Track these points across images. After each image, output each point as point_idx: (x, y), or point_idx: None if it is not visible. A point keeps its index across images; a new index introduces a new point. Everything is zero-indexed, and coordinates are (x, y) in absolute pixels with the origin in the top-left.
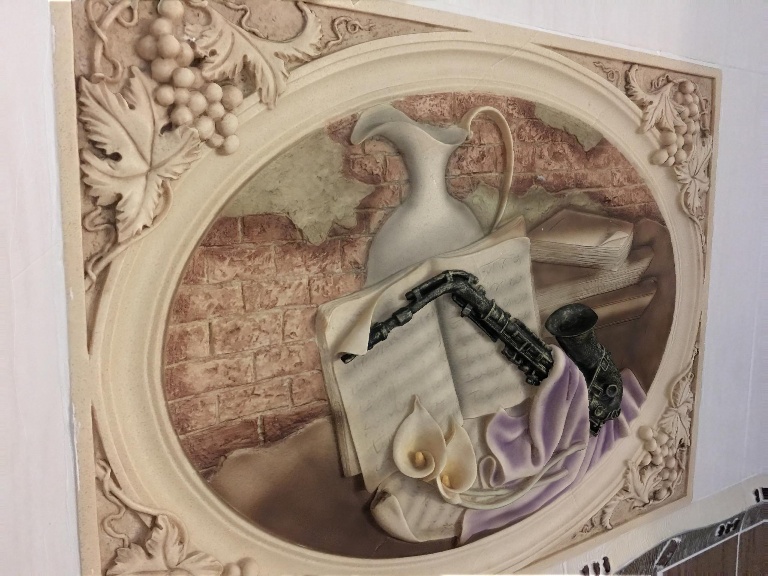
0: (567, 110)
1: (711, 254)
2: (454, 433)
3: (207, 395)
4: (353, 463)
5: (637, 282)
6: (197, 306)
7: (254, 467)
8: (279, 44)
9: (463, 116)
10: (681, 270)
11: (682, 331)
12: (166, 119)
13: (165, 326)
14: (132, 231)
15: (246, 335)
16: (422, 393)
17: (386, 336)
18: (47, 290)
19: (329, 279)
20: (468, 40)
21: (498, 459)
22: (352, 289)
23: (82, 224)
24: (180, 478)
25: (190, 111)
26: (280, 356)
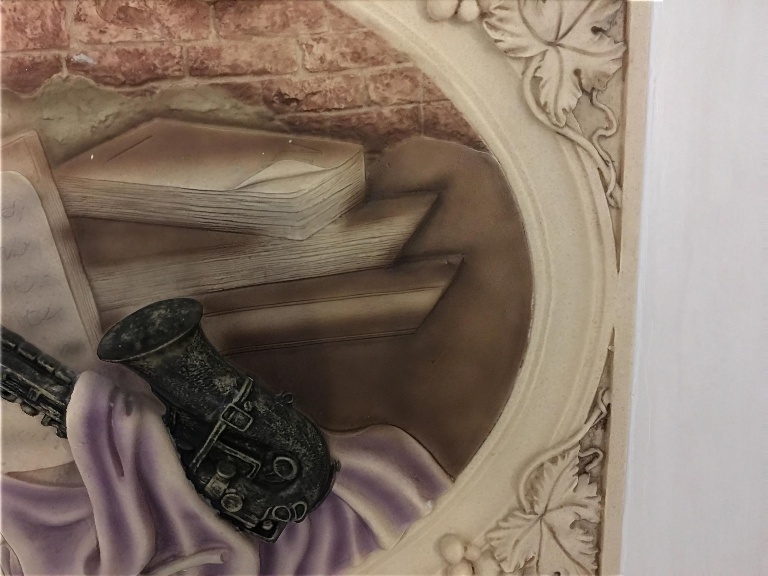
0: None
1: (643, 211)
2: None
3: None
4: None
5: (385, 263)
6: None
7: None
8: None
9: None
10: (551, 243)
11: (565, 365)
12: None
13: None
14: None
15: None
16: None
17: None
18: None
19: None
20: None
21: (15, 552)
22: None
23: None
24: None
25: None
26: None
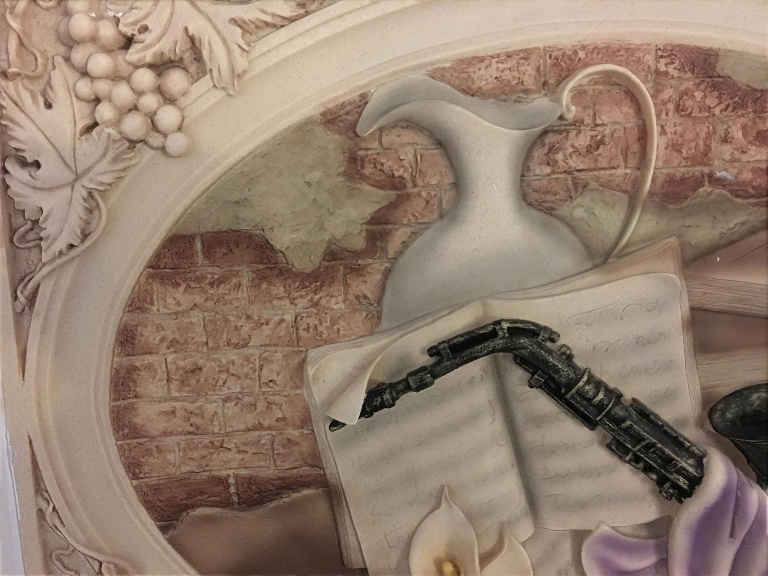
0: None
1: None
2: (503, 549)
3: (164, 440)
4: (356, 553)
5: None
6: (147, 338)
7: (222, 531)
8: (239, 6)
9: (562, 82)
10: None
11: None
12: (90, 118)
13: (112, 357)
14: (54, 251)
15: (210, 377)
16: (457, 485)
17: (390, 404)
18: None
19: (324, 317)
20: None
21: None
22: (359, 332)
23: (12, 240)
24: (137, 525)
25: (112, 106)
26: (256, 407)
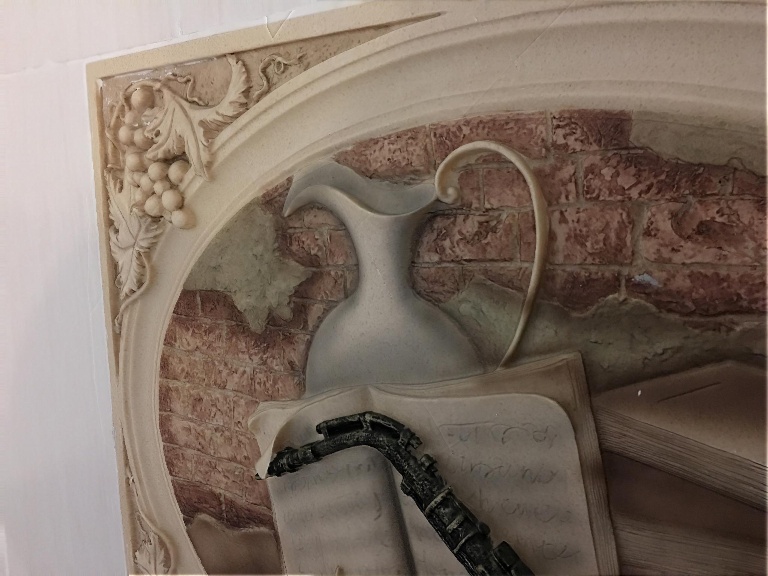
0: (755, 113)
1: None
2: None
3: (186, 450)
4: None
5: None
6: (174, 367)
7: (215, 539)
8: (207, 110)
9: None
10: None
11: None
12: None
13: None
14: (123, 293)
15: (207, 408)
16: (348, 570)
17: (287, 468)
18: (100, 328)
19: (269, 375)
20: (440, 30)
21: None
22: (291, 395)
23: None
24: (176, 512)
25: (142, 191)
26: (232, 441)
